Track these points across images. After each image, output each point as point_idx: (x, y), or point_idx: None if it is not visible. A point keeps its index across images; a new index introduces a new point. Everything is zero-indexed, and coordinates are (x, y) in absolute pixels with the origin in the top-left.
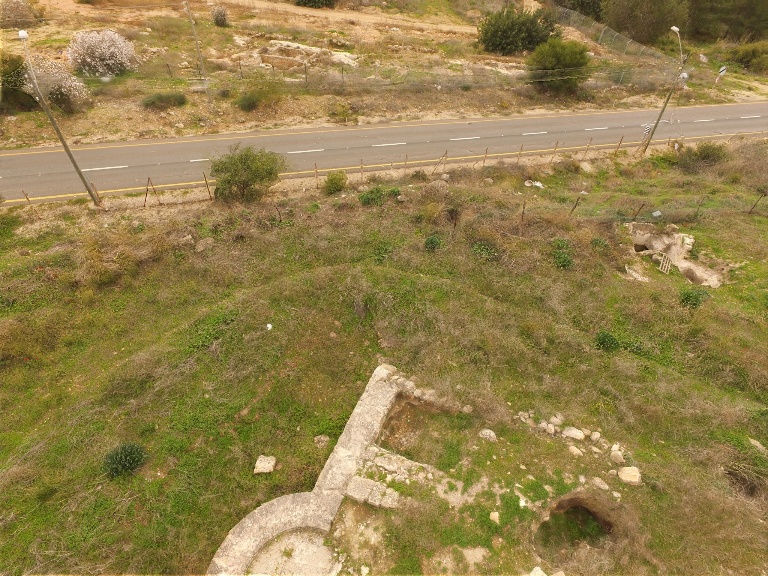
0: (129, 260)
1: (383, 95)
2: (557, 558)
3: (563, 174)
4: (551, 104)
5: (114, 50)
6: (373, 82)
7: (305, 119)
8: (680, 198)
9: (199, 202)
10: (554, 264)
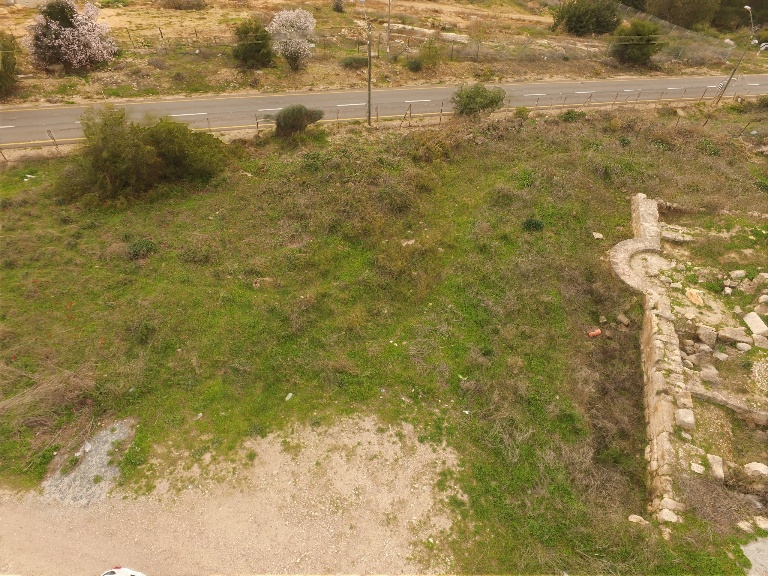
0: (448, 144)
1: (508, 62)
2: None
3: (666, 116)
4: (631, 72)
5: (309, 24)
6: (496, 53)
7: (458, 79)
8: (762, 126)
9: (433, 126)
10: (707, 153)
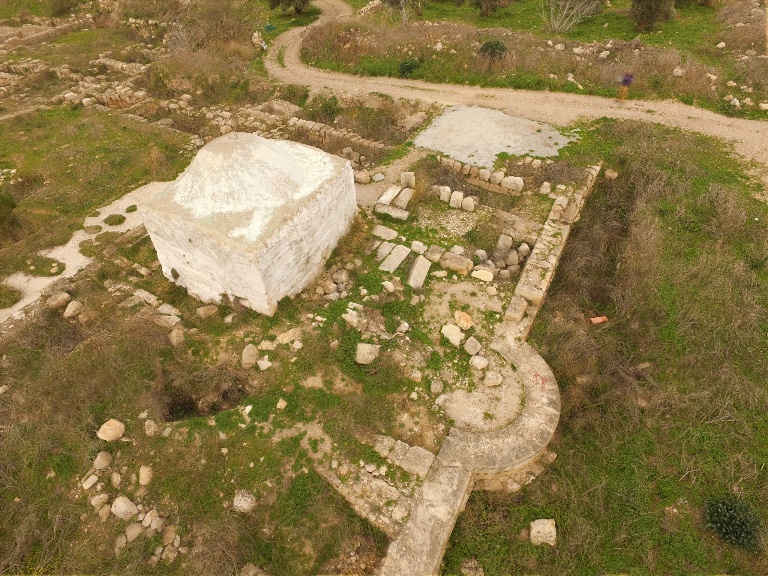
0: None
1: None
2: (234, 401)
3: None
4: None
5: None
6: None
7: None
8: None
9: None
10: None
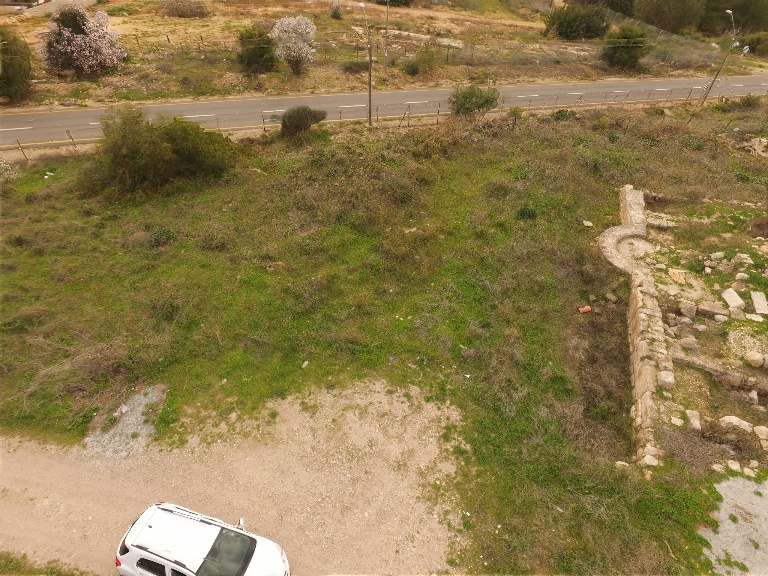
0: (446, 141)
1: (501, 66)
2: None
3: (653, 115)
4: (620, 75)
5: (309, 30)
6: (490, 57)
7: (453, 81)
8: (745, 124)
9: (430, 125)
10: (691, 148)
